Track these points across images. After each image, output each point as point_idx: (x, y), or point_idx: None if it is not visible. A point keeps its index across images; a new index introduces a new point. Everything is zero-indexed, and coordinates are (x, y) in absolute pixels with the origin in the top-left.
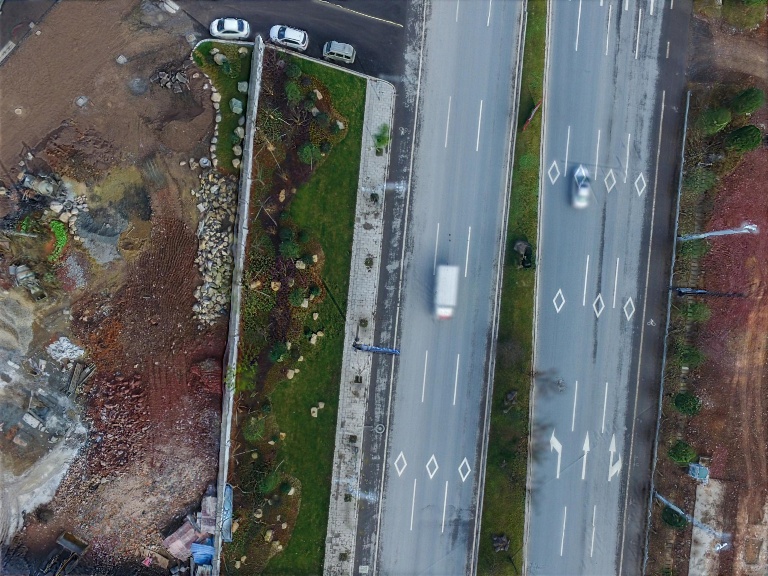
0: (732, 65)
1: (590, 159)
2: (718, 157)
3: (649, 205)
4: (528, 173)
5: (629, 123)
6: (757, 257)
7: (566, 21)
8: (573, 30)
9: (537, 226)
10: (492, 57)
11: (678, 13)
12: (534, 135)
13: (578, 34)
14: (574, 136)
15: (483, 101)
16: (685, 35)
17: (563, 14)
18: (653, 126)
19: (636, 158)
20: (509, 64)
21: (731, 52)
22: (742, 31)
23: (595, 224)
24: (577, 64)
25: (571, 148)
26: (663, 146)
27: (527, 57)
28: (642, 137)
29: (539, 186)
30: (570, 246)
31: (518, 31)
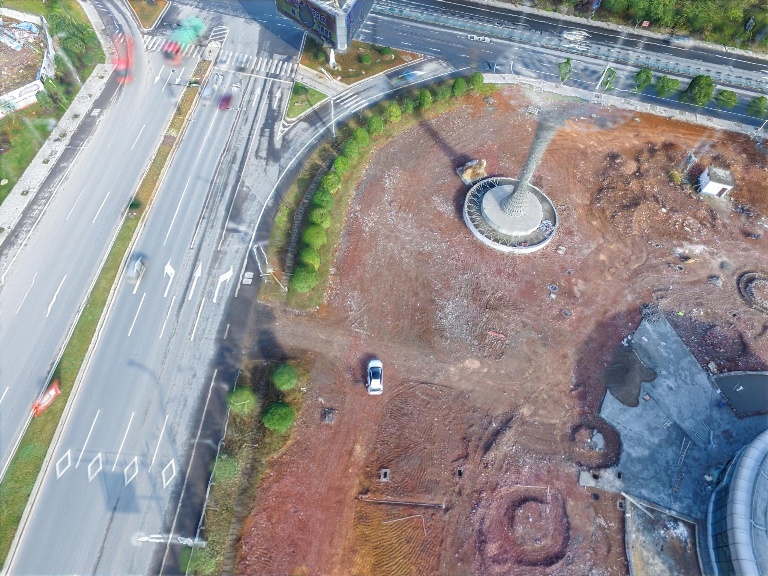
0: (292, 342)
1: (113, 446)
2: (265, 437)
3: (175, 499)
4: (24, 467)
5: (170, 404)
6: (308, 565)
7: (125, 311)
8: (130, 318)
9: (14, 536)
10: (37, 345)
11: (242, 300)
12: (49, 422)
13: (135, 321)
14: (101, 421)
15: (9, 388)
16: (247, 318)
17: (124, 305)
18: (198, 406)
19: (170, 442)
20: (53, 351)
21: (292, 331)
22: (304, 313)
23: (97, 529)
24: (126, 348)
25: (93, 434)
26: (205, 427)
27: (70, 344)
28: (182, 418)
29: (36, 482)
30: (53, 563)
31: (73, 321)
